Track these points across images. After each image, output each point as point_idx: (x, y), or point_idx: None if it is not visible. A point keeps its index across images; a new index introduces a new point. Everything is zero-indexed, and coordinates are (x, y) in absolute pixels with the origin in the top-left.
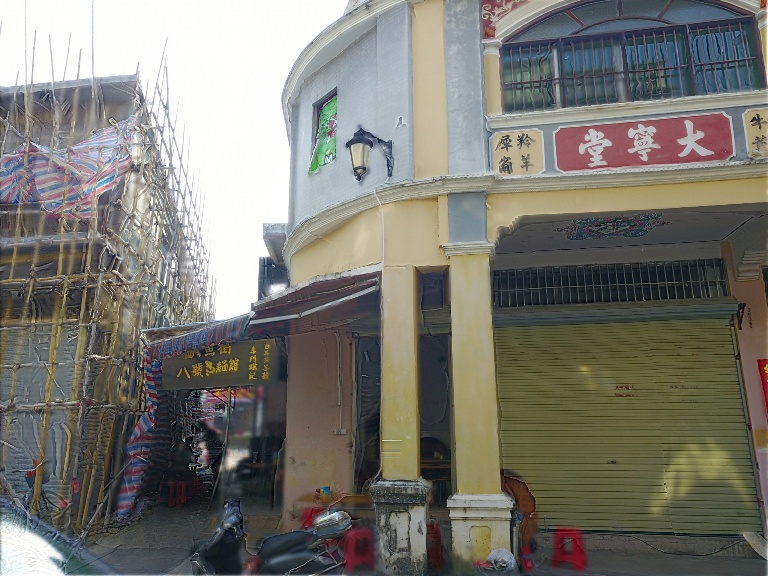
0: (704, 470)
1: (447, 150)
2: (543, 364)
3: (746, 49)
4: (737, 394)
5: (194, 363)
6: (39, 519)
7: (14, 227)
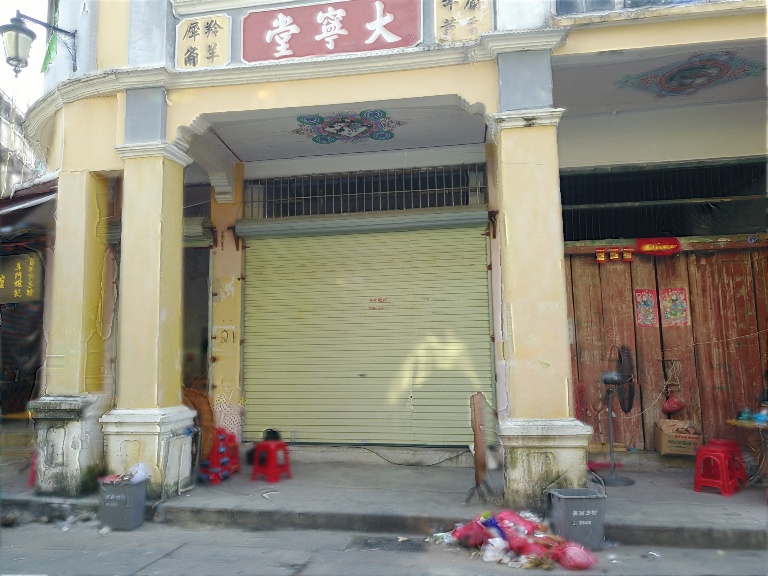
0: (448, 382)
1: (128, 40)
2: (300, 277)
3: None
4: (485, 305)
5: None
6: None
7: None
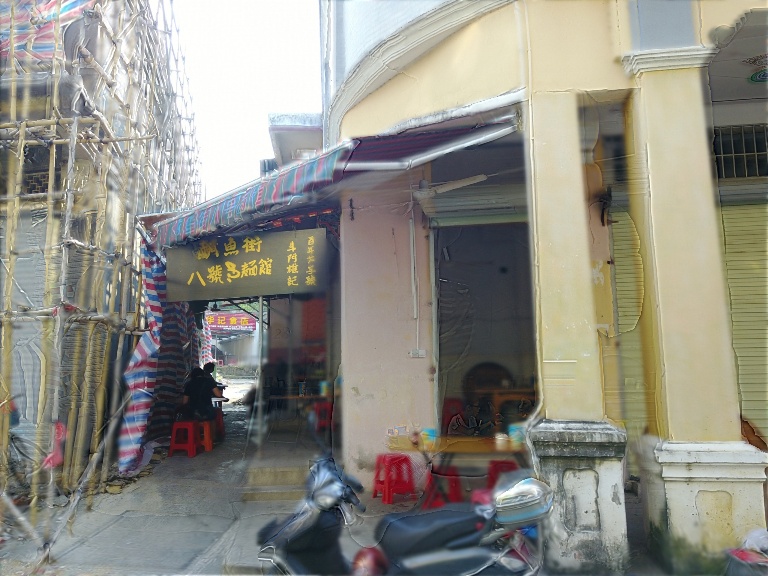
0: None
1: None
2: None
3: None
4: None
5: (210, 265)
6: (4, 483)
7: None
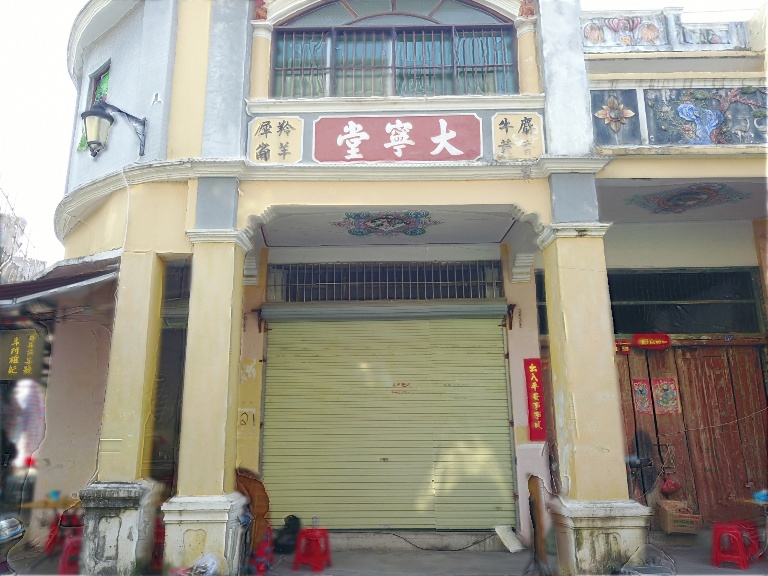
0: (469, 466)
1: (202, 132)
2: (324, 361)
3: (505, 55)
4: (503, 392)
5: None
6: None
7: None
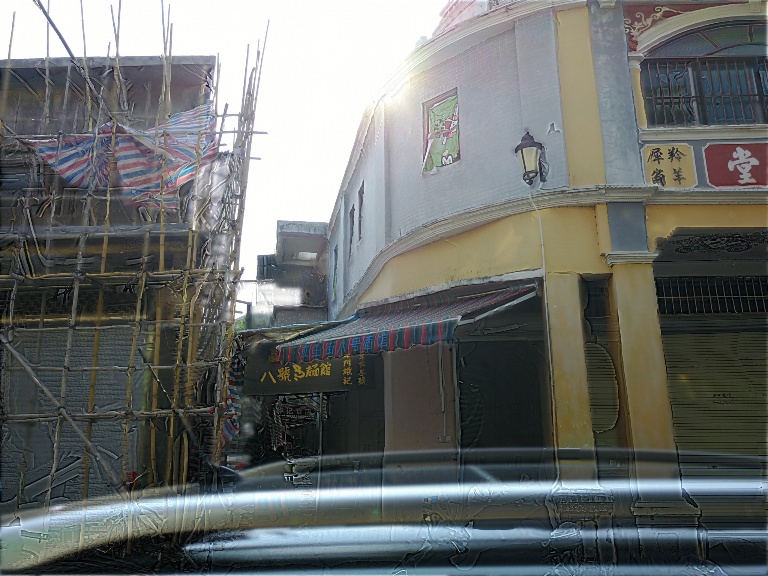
0: None
1: (603, 159)
2: None
3: None
4: None
5: (280, 367)
6: None
7: (80, 214)
